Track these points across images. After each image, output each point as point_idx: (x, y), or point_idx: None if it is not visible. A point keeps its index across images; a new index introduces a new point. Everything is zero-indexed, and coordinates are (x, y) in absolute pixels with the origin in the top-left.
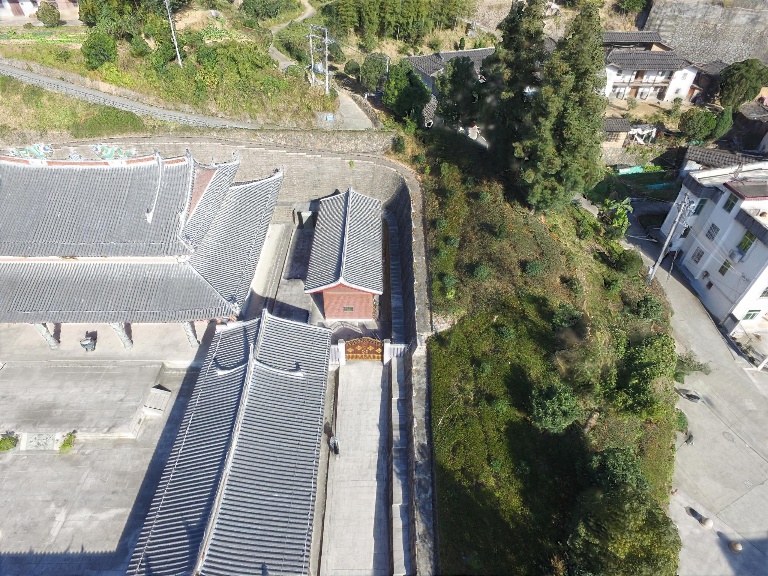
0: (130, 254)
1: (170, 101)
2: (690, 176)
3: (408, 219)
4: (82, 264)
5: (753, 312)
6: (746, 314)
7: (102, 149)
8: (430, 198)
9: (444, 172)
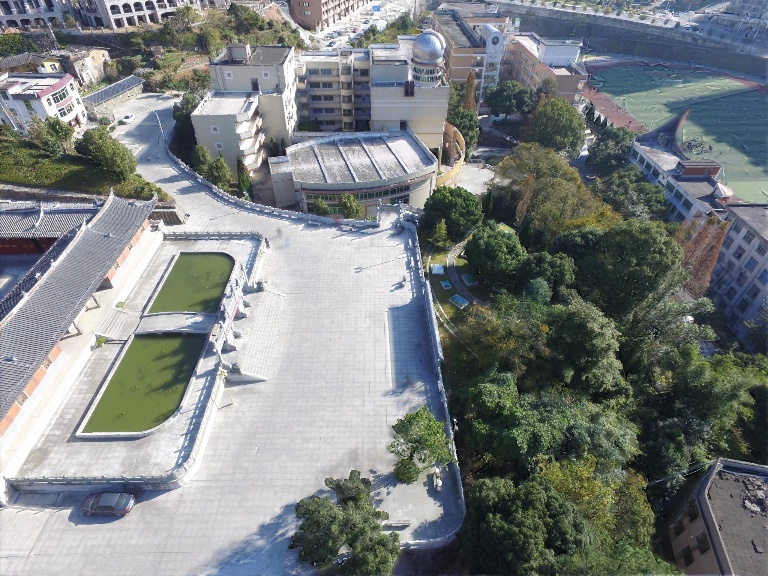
0: None
1: None
2: None
3: None
4: None
5: None
6: None
7: None
8: None
9: None
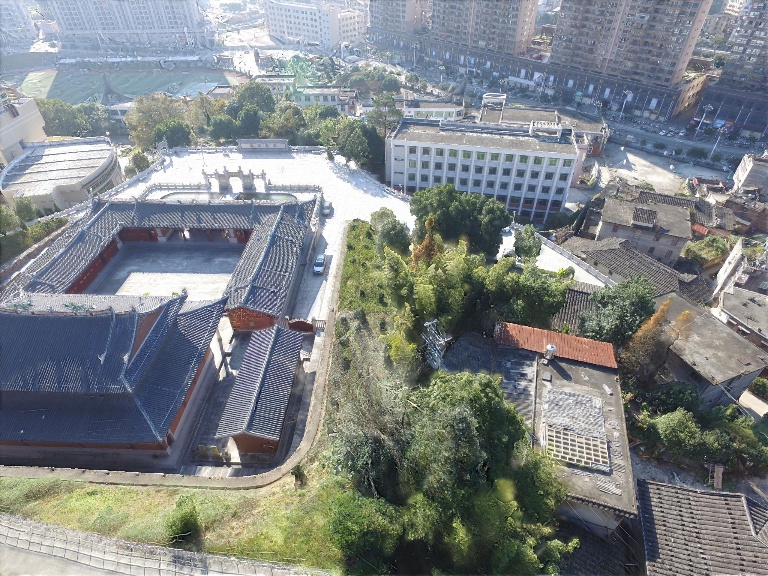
0: None
1: None
2: None
3: None
4: None
5: None
6: None
7: None
8: None
9: None
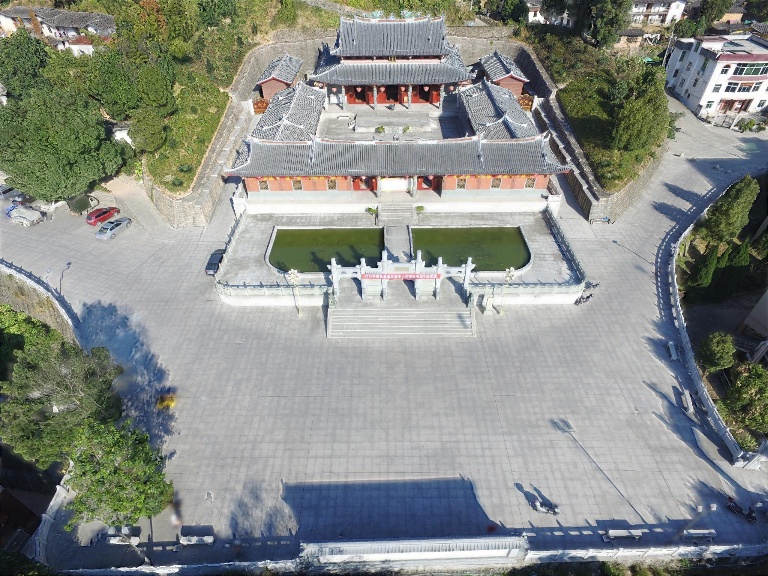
0: (426, 54)
1: (385, 15)
2: (677, 40)
3: (530, 62)
4: (397, 65)
5: (710, 103)
6: (707, 104)
7: (406, 13)
8: (541, 51)
9: (548, 38)
